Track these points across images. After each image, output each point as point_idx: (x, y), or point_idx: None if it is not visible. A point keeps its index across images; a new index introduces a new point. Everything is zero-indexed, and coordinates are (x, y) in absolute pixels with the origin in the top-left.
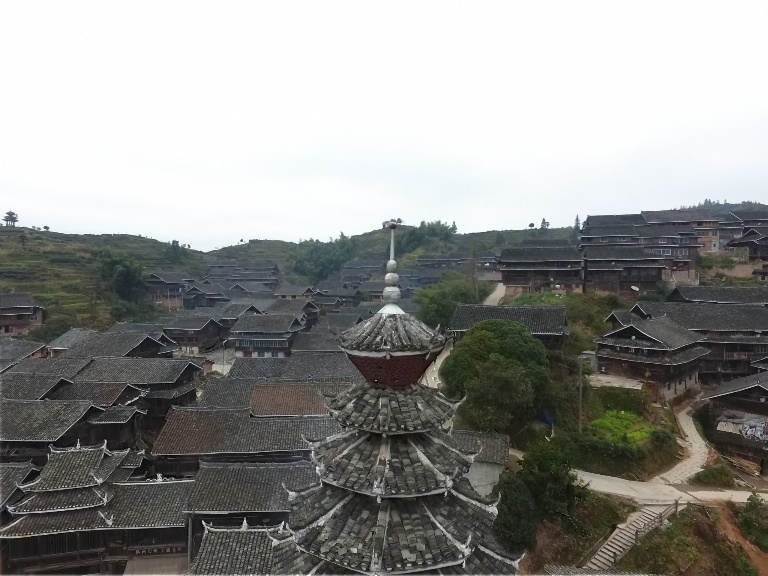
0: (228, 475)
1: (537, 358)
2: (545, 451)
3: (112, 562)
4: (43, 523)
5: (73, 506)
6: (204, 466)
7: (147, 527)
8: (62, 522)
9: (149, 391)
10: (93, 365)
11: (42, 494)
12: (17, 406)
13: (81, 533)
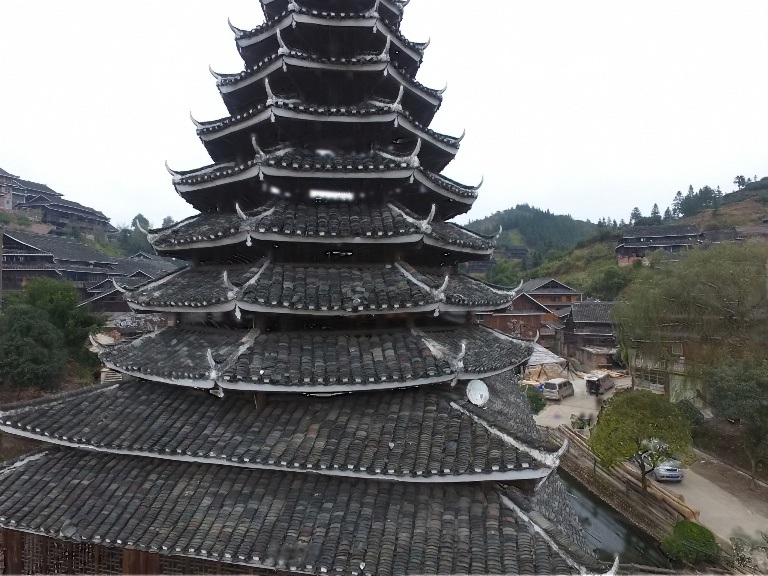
0: None
1: None
2: (52, 284)
3: None
4: None
5: None
6: None
7: None
8: None
9: None
10: None
11: None
12: None
13: None
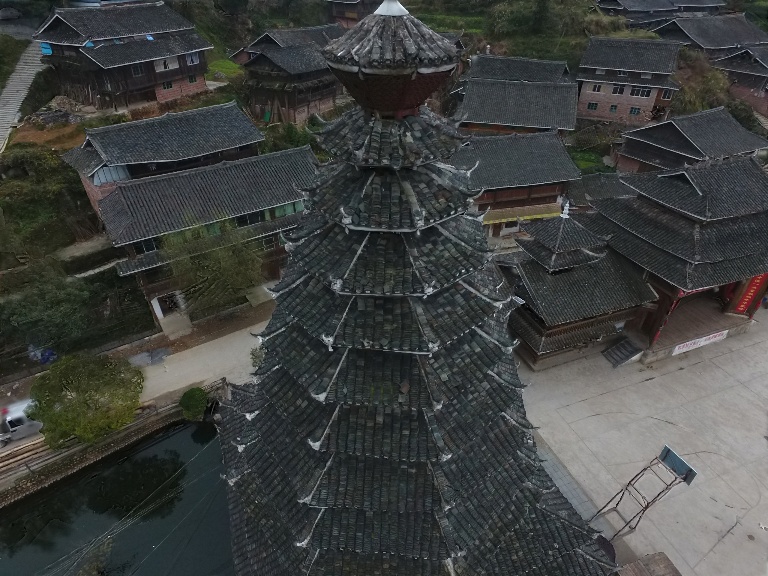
0: None
1: None
2: None
3: None
4: None
5: None
6: None
7: None
8: None
9: None
10: None
11: None
12: None
13: None
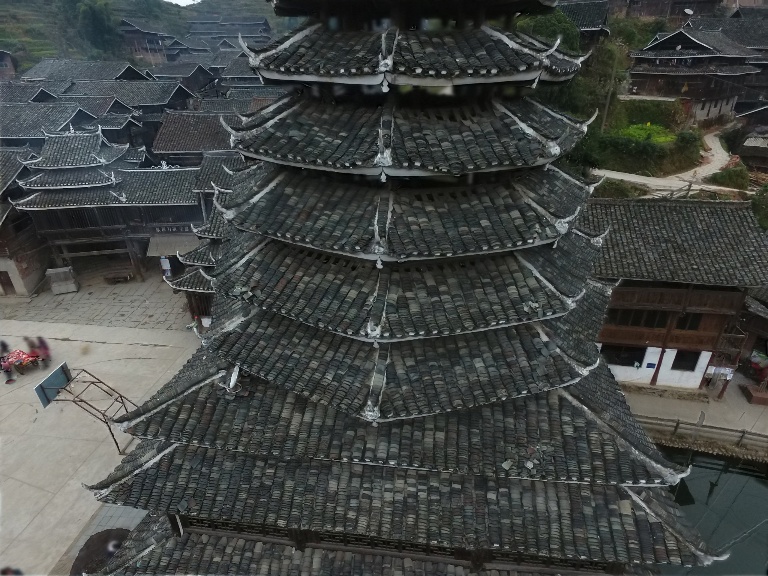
0: (234, 163)
1: (570, 42)
2: None
3: (136, 238)
4: (58, 199)
5: (83, 183)
6: (208, 155)
7: (161, 204)
8: (76, 198)
9: (142, 113)
10: (75, 88)
11: (48, 173)
12: (1, 109)
13: (98, 210)
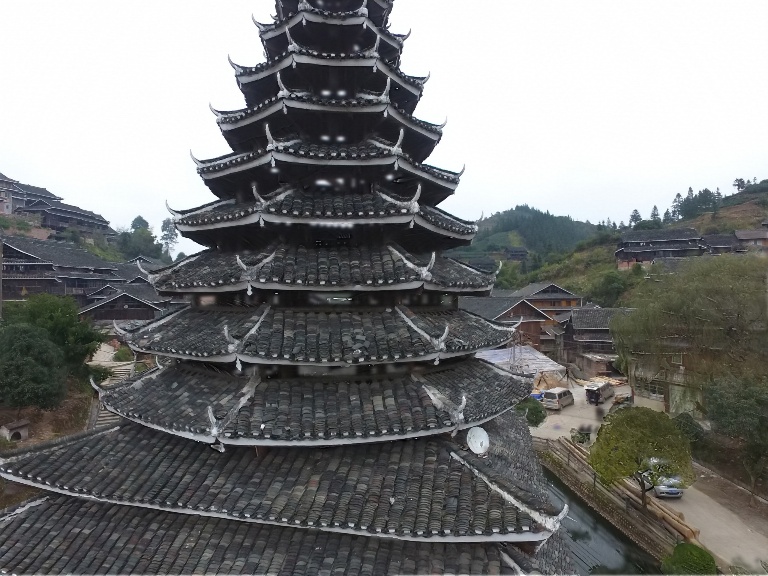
0: None
1: None
2: (52, 300)
3: None
4: None
5: None
6: None
7: None
8: None
9: None
10: None
11: None
12: None
13: None
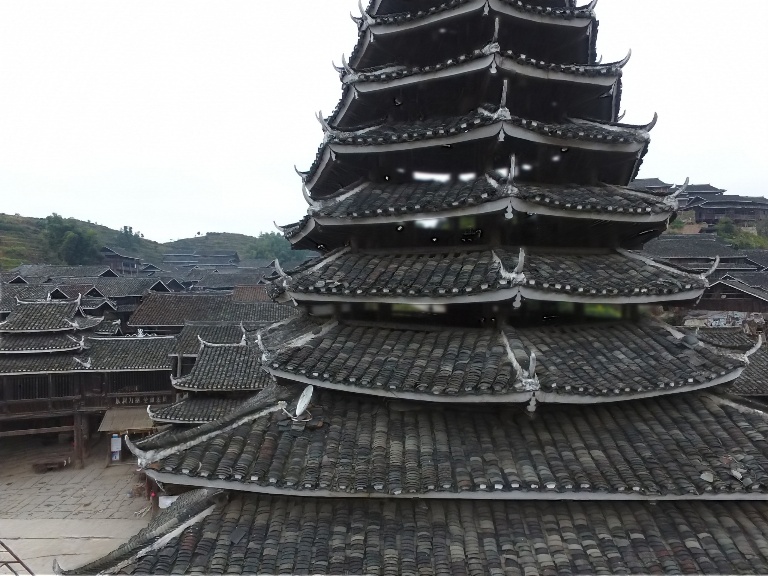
0: (216, 330)
1: None
2: None
3: (88, 412)
4: (10, 365)
5: (45, 348)
6: (189, 324)
7: (130, 370)
8: (32, 365)
9: (115, 304)
10: None
11: (8, 338)
12: None
13: (54, 378)
